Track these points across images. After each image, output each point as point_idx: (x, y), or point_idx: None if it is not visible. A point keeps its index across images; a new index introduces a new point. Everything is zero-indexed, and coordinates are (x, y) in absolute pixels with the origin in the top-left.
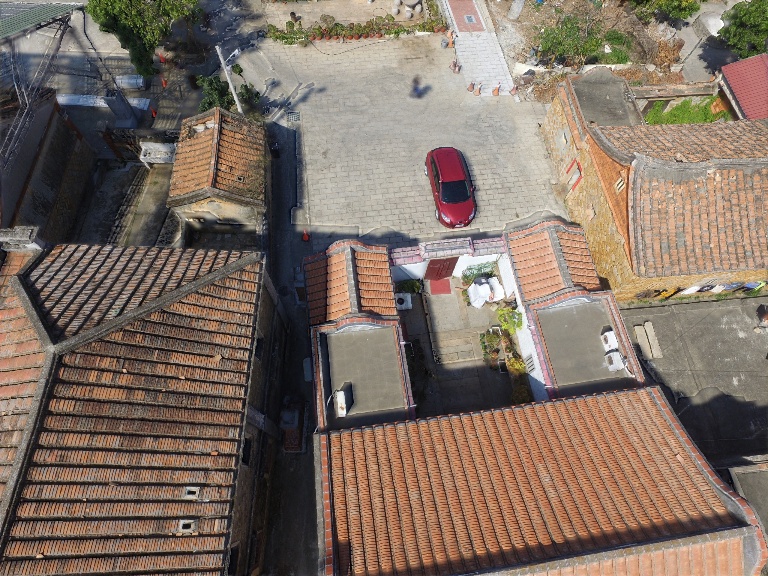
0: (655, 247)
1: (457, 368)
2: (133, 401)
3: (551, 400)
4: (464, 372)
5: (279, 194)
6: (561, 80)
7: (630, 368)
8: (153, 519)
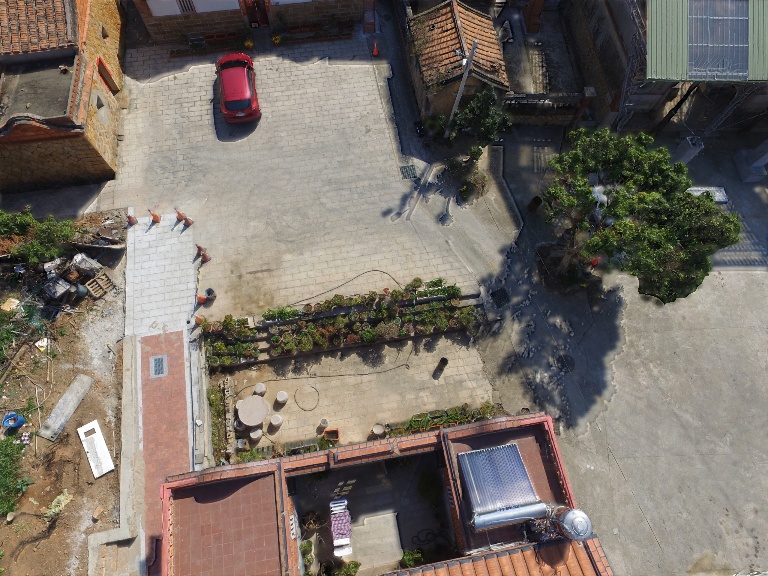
0: None
1: None
2: None
3: None
4: None
5: (406, 88)
6: None
7: None
8: None
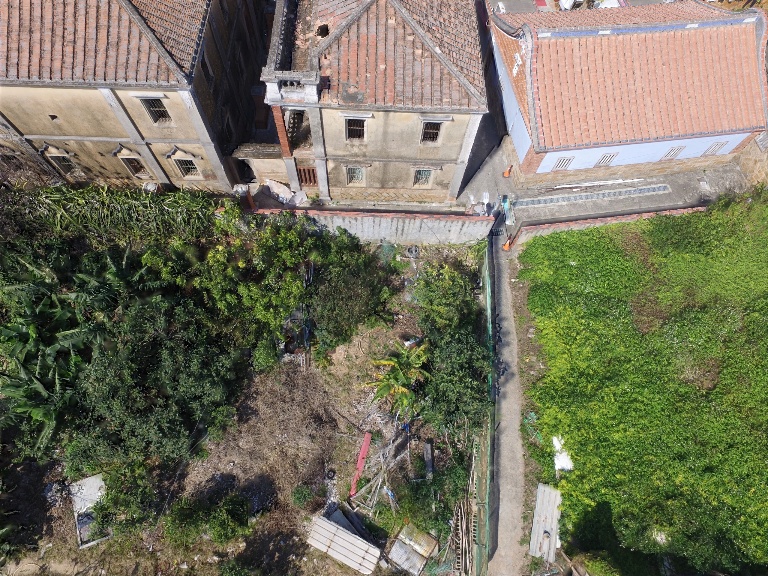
0: None
1: None
2: None
3: None
4: None
5: None
6: None
7: None
8: None
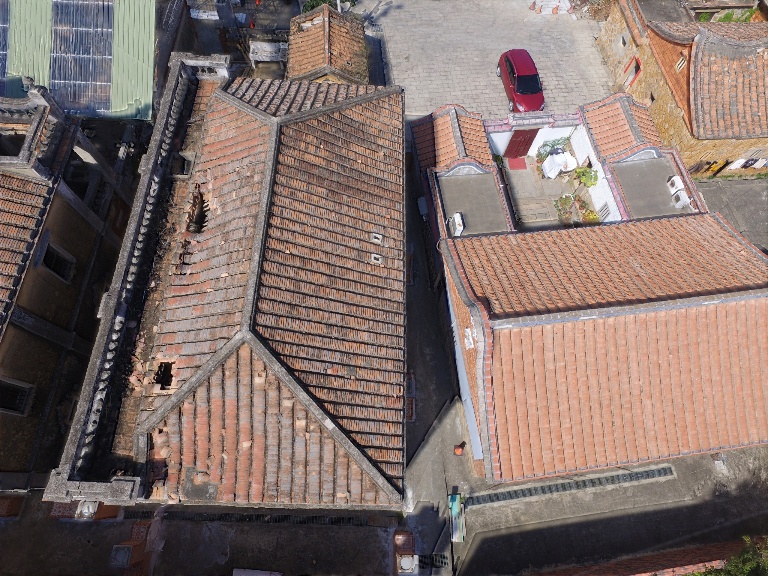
0: (712, 113)
1: (536, 226)
2: (330, 169)
3: (632, 222)
4: (542, 229)
5: None
6: (613, 1)
7: (694, 205)
8: (354, 249)
